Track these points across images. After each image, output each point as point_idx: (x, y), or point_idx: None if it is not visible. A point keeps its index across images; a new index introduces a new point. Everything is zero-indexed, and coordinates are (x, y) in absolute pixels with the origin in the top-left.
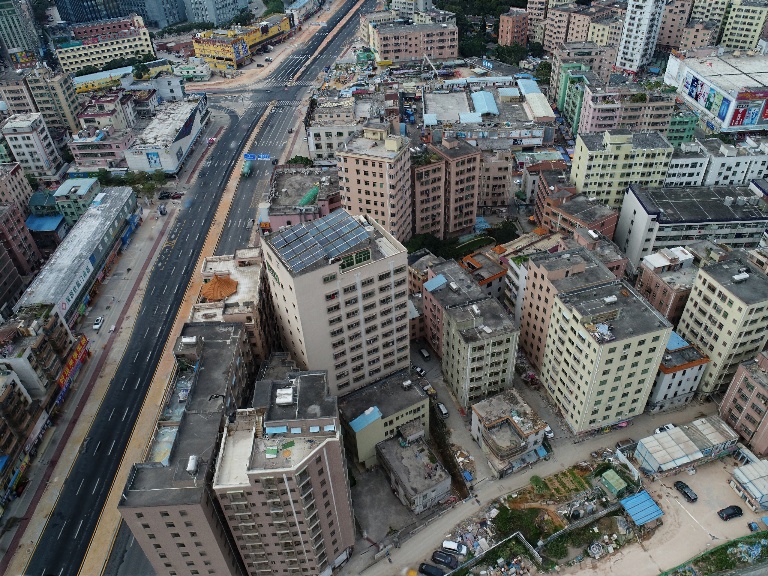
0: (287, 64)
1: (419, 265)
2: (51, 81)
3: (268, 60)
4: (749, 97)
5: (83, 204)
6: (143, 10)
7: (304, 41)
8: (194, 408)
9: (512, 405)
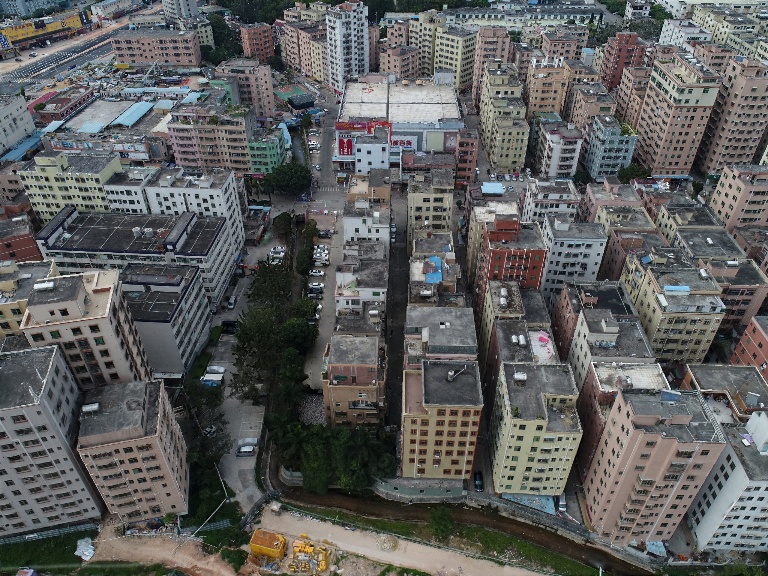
0: (45, 60)
1: None
2: None
3: (32, 55)
4: (348, 127)
5: None
6: None
7: (89, 39)
8: None
9: None
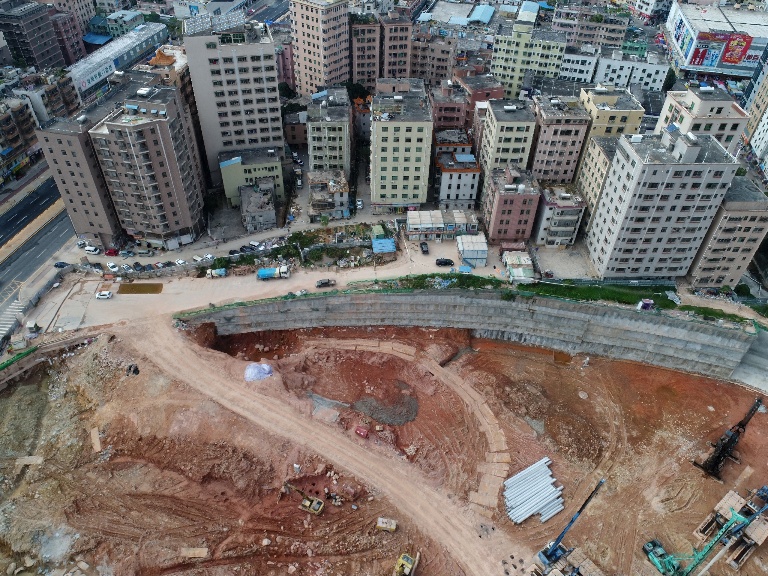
0: None
1: None
2: None
3: None
4: (709, 38)
5: (126, 29)
6: None
7: None
8: (104, 105)
9: (335, 177)
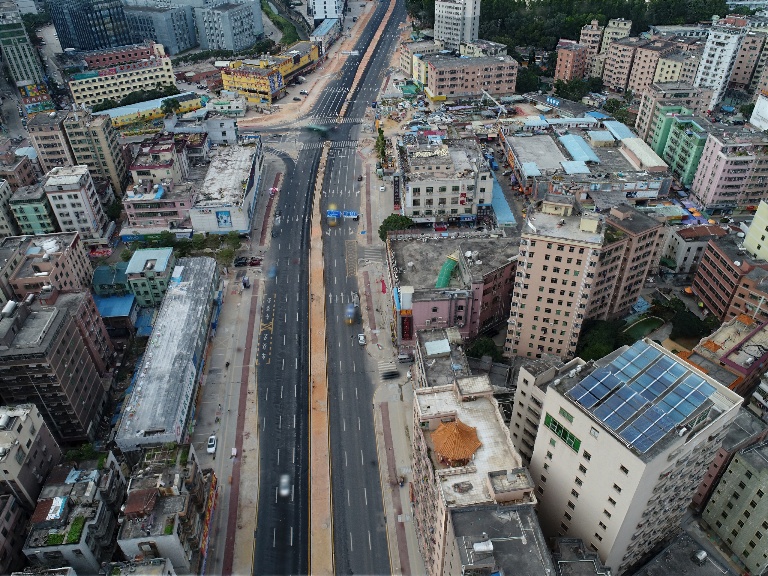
0: (326, 98)
1: None
2: (93, 126)
3: (304, 93)
4: None
5: (161, 282)
6: (152, 35)
7: (336, 71)
8: None
9: None
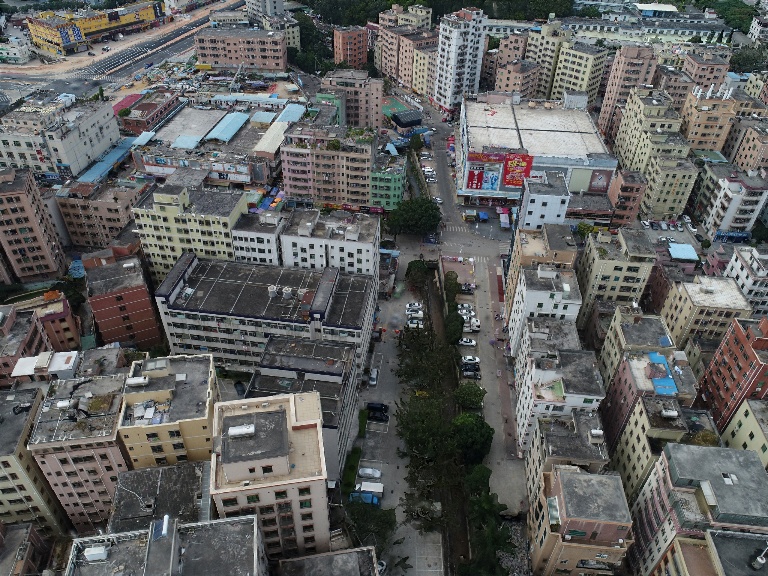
0: (119, 56)
1: None
2: None
3: (105, 49)
4: (482, 159)
5: None
6: None
7: (163, 33)
8: None
9: None
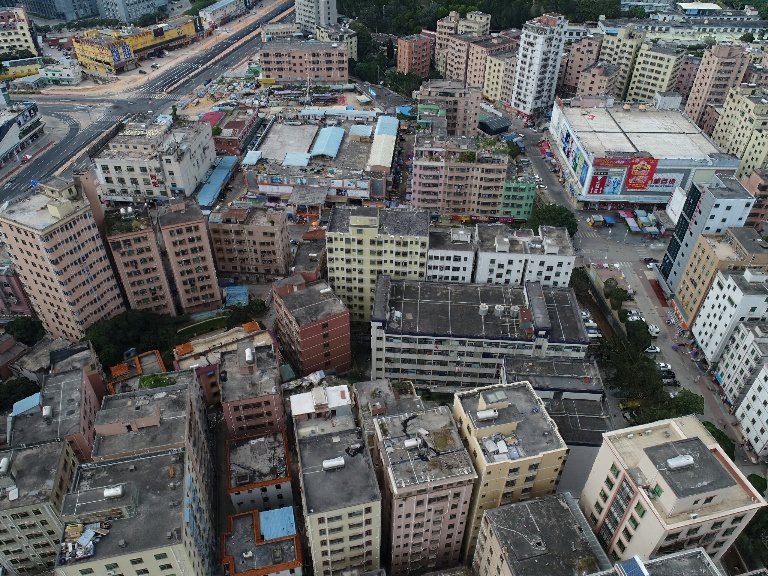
0: (171, 73)
1: (65, 364)
2: None
3: (154, 66)
4: (607, 164)
5: None
6: (50, 0)
7: (206, 48)
8: None
9: None
